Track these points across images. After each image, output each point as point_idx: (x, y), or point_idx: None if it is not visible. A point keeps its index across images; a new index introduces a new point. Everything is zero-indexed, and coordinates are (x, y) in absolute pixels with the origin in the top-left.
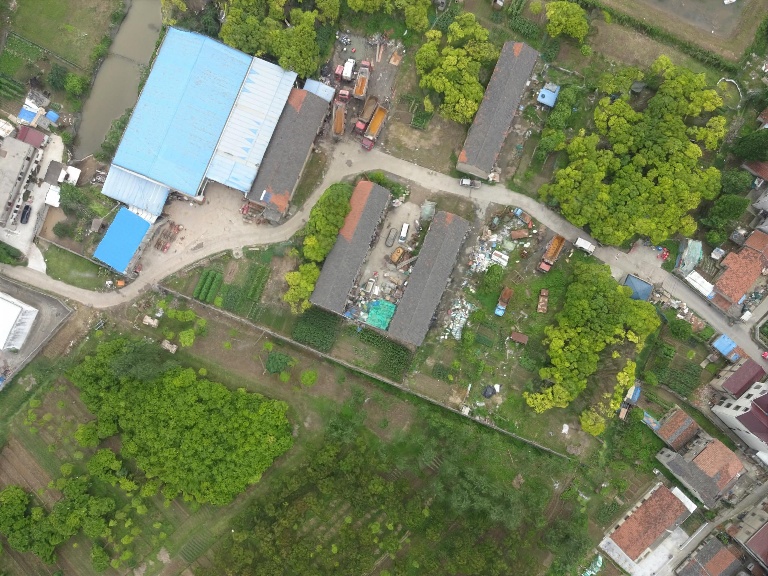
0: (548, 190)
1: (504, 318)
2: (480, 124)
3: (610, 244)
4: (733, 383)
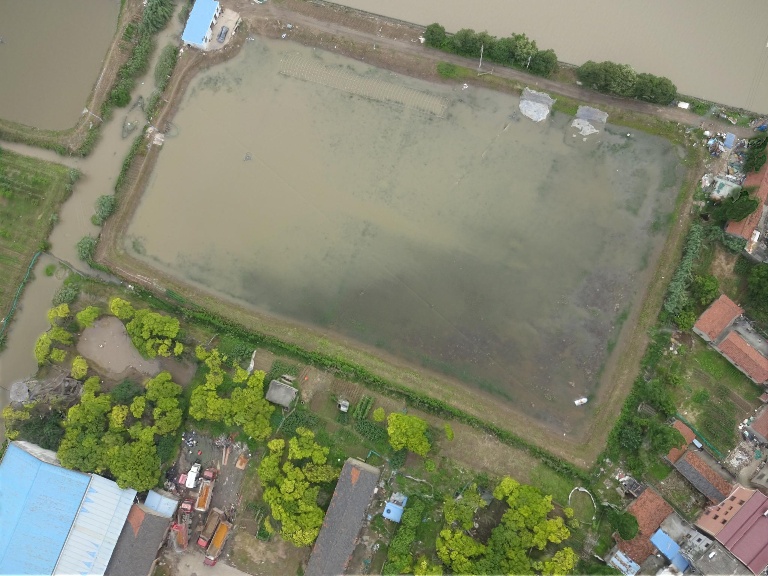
0: None
1: None
2: (318, 556)
3: None
4: None
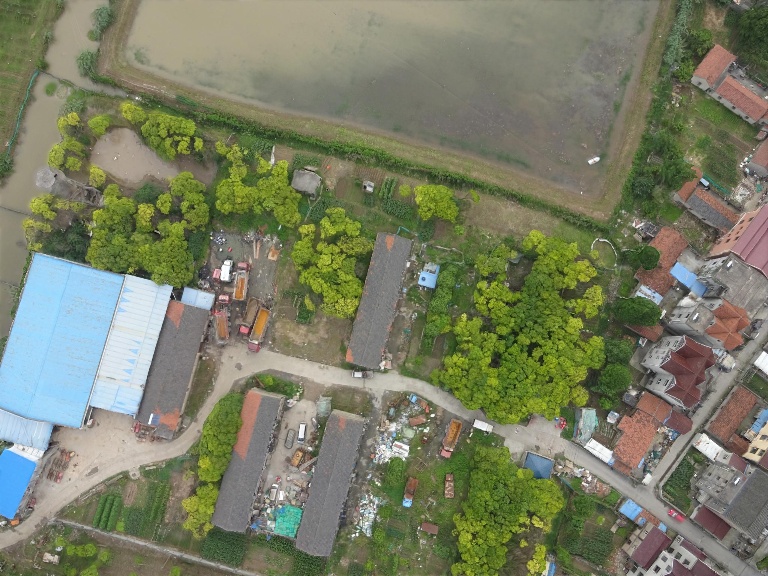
0: (439, 377)
1: (413, 508)
2: (362, 321)
3: (507, 423)
4: (641, 555)
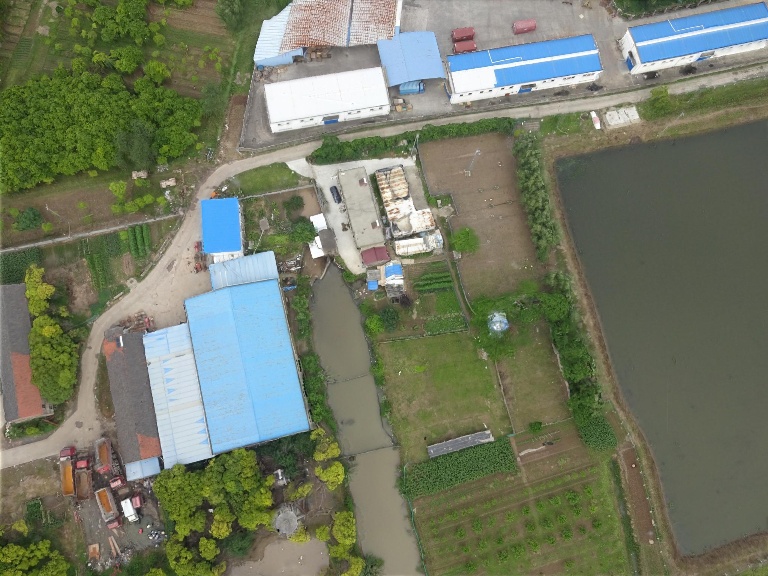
0: None
1: None
2: None
3: None
4: None
